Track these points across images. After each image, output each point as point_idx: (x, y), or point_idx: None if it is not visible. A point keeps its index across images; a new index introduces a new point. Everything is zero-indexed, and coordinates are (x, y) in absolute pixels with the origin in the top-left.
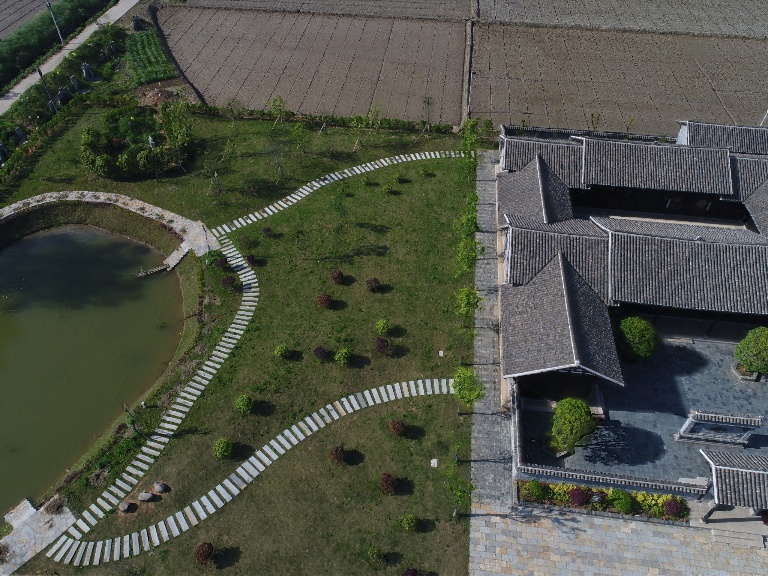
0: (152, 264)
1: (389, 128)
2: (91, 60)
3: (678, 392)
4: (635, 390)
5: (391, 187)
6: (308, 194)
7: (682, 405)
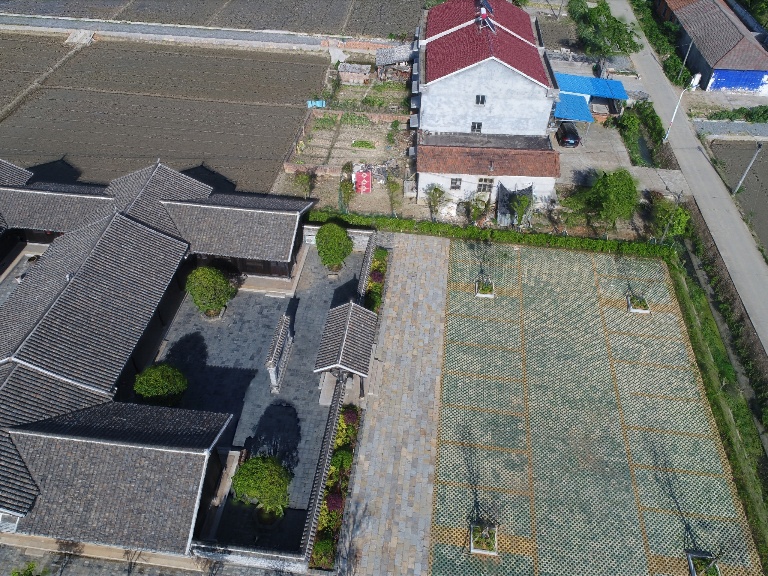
0: None
1: None
2: None
3: (224, 373)
4: None
5: None
6: None
7: (240, 375)
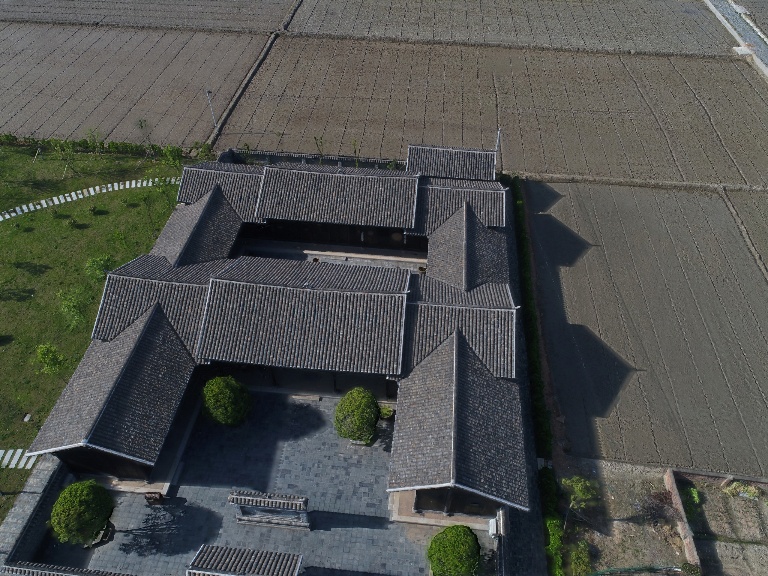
0: None
1: (118, 152)
2: None
3: (272, 461)
4: (224, 460)
5: (73, 220)
6: None
7: (268, 477)
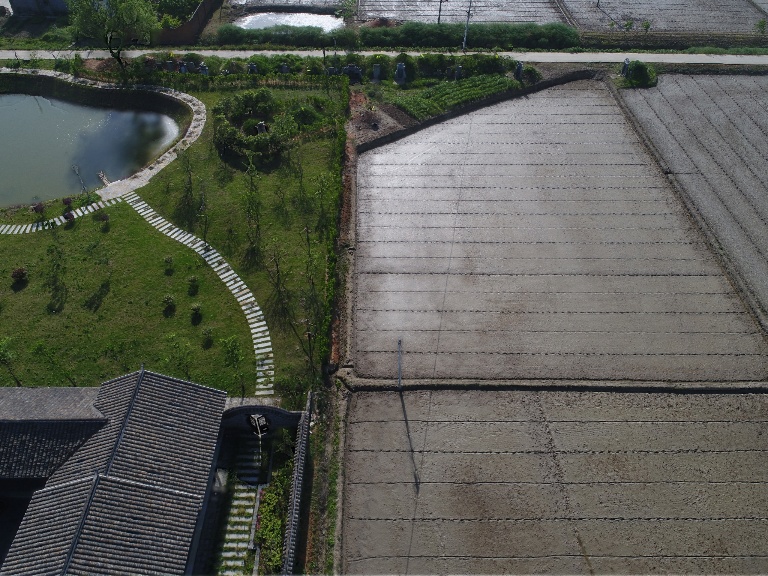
0: (116, 178)
1: None
2: (427, 68)
3: None
4: None
5: (166, 300)
6: (180, 241)
7: None
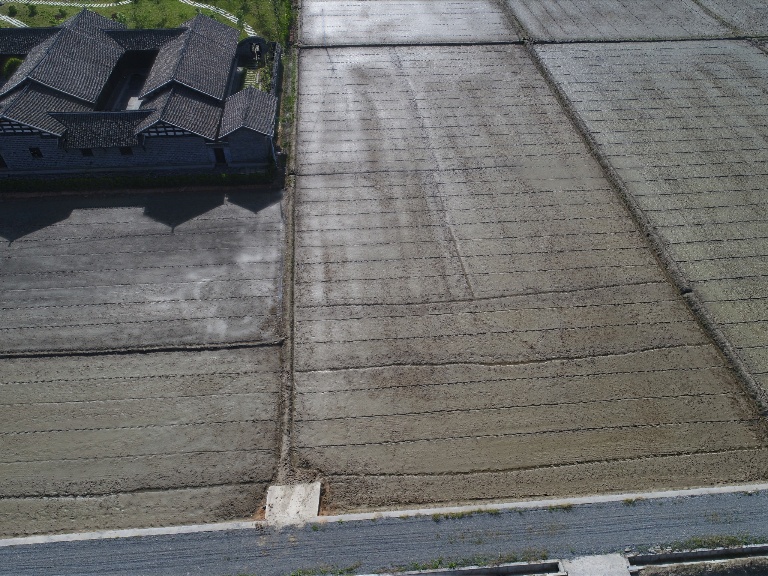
0: None
1: None
2: None
3: None
4: None
5: None
6: (201, 7)
7: None
